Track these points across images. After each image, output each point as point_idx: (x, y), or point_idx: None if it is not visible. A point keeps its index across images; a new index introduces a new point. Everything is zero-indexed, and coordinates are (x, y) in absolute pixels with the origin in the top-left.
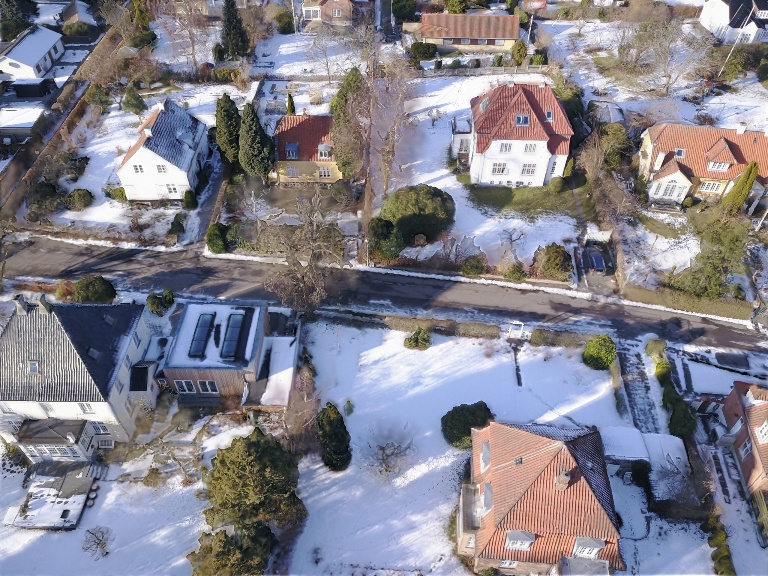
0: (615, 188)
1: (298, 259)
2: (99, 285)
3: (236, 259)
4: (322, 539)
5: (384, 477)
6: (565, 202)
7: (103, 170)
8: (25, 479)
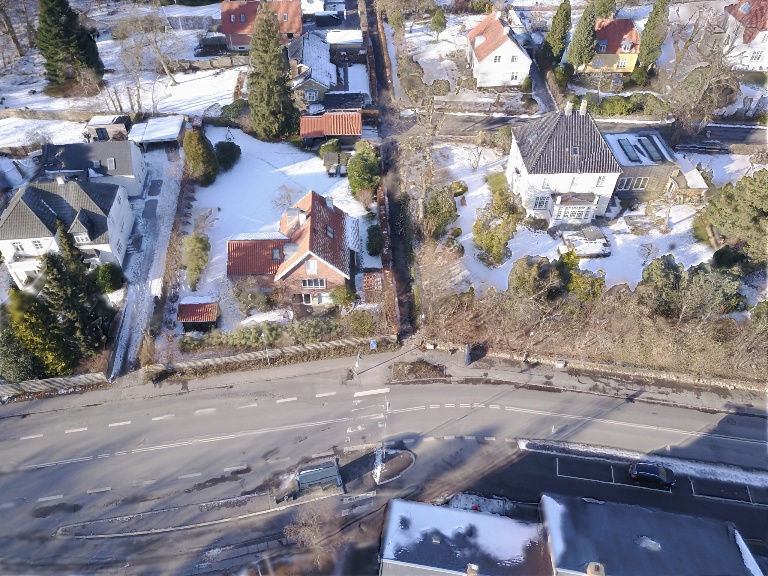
0: None
1: (632, 119)
2: None
3: None
4: None
5: None
6: None
7: (438, 70)
8: (552, 235)
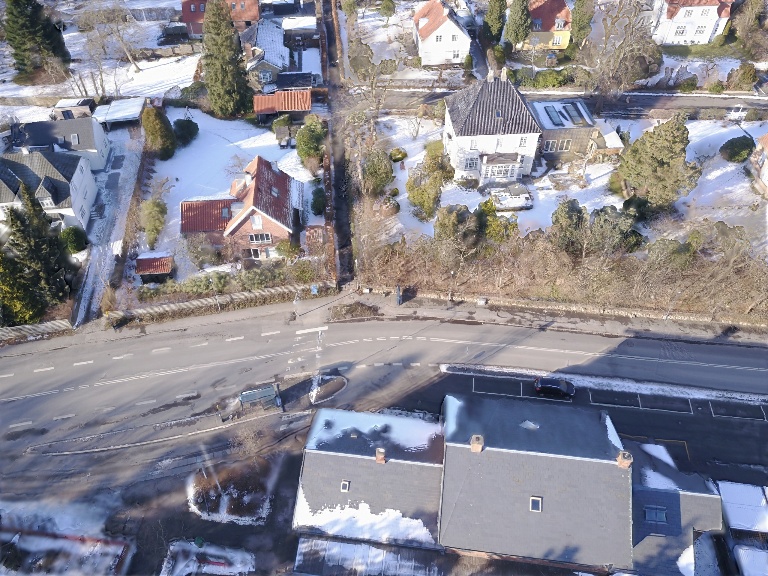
0: None
1: (564, 91)
2: None
3: None
4: (683, 200)
5: None
6: (728, 51)
7: (387, 51)
8: (481, 193)
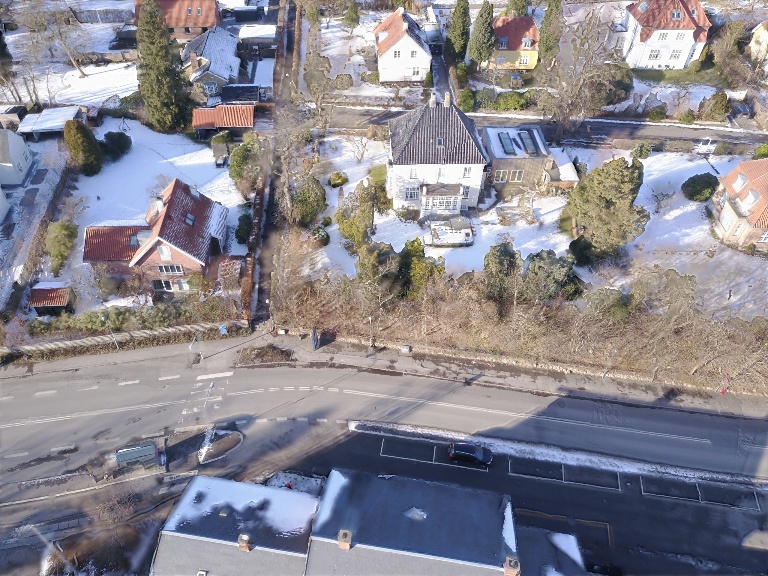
0: (741, 65)
1: (526, 115)
2: None
3: (481, 116)
4: (636, 242)
5: (657, 216)
6: (703, 78)
7: None
8: (421, 225)
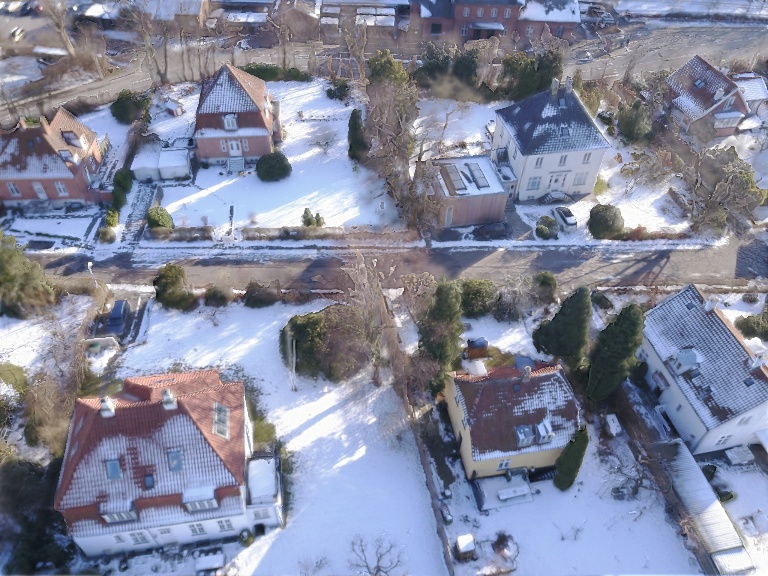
0: (41, 396)
1: None
2: (598, 209)
3: None
4: None
5: None
6: None
7: None
8: None
